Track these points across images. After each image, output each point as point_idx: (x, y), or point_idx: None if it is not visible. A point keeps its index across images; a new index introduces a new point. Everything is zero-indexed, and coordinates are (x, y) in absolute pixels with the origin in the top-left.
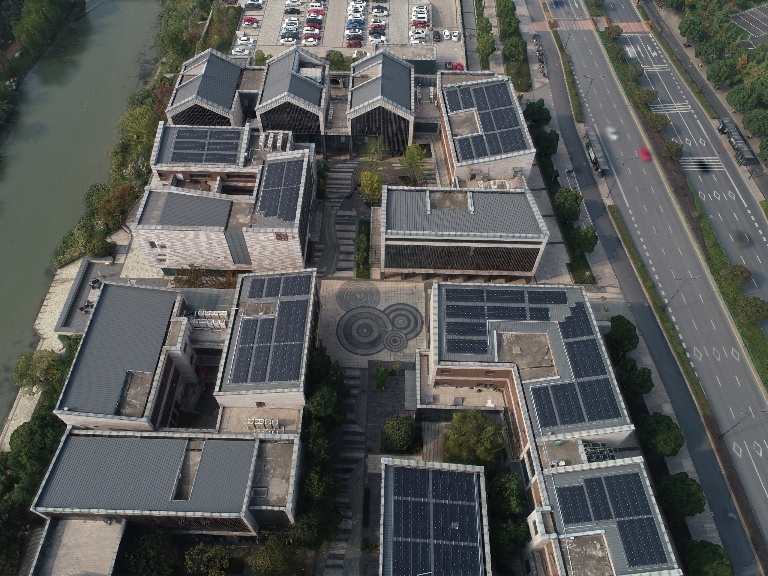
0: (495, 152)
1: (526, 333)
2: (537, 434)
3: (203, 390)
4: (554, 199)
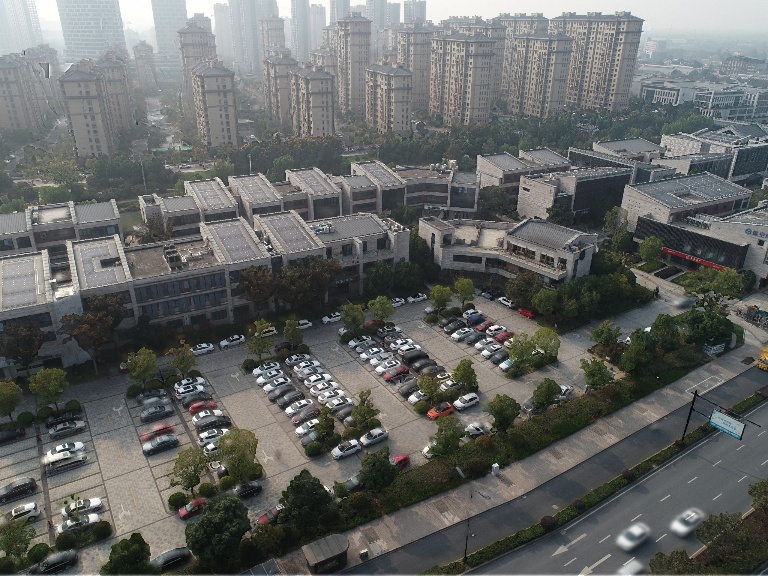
0: None
1: None
2: None
3: None
4: None
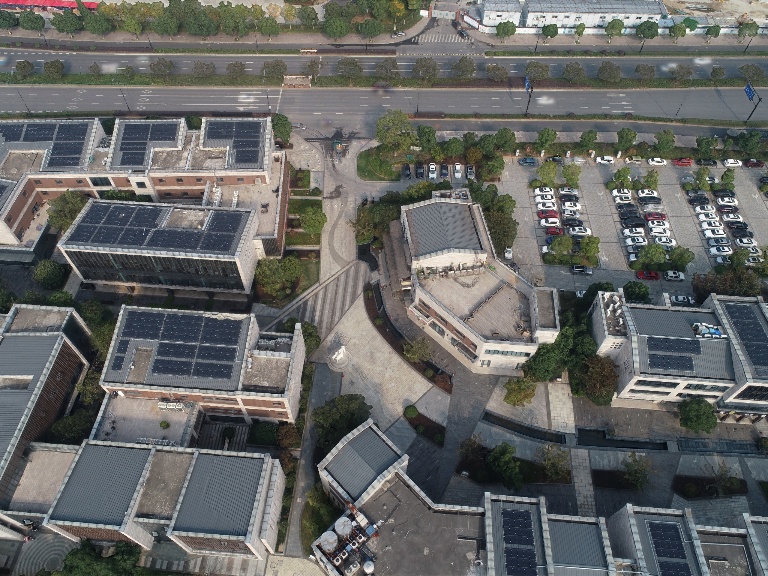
0: None
1: (3, 162)
2: (81, 169)
3: None
4: None
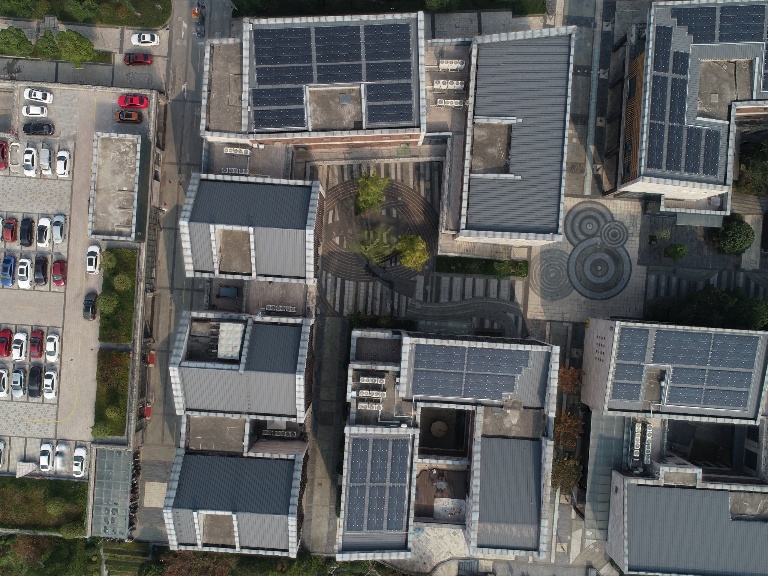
0: (406, 72)
1: None
2: None
3: (667, 440)
4: (433, 8)
